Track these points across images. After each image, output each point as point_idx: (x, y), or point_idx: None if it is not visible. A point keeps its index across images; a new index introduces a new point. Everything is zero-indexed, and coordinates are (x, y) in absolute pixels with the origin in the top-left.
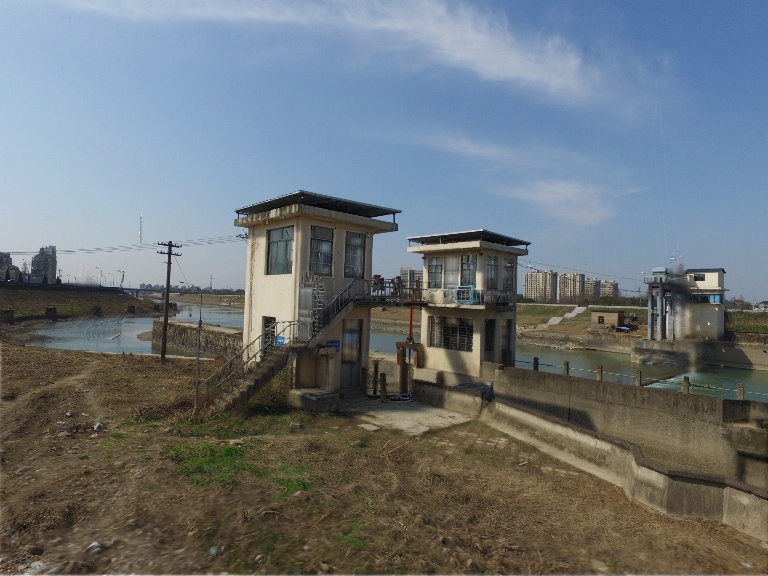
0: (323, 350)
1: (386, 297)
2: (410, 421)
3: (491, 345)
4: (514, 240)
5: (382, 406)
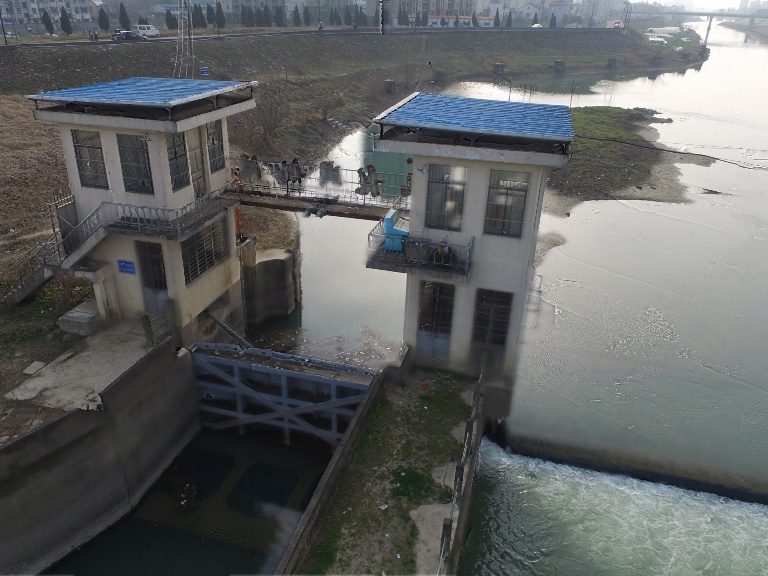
0: (80, 273)
1: (338, 197)
2: (52, 382)
3: (445, 325)
4: (500, 134)
5: (121, 351)
